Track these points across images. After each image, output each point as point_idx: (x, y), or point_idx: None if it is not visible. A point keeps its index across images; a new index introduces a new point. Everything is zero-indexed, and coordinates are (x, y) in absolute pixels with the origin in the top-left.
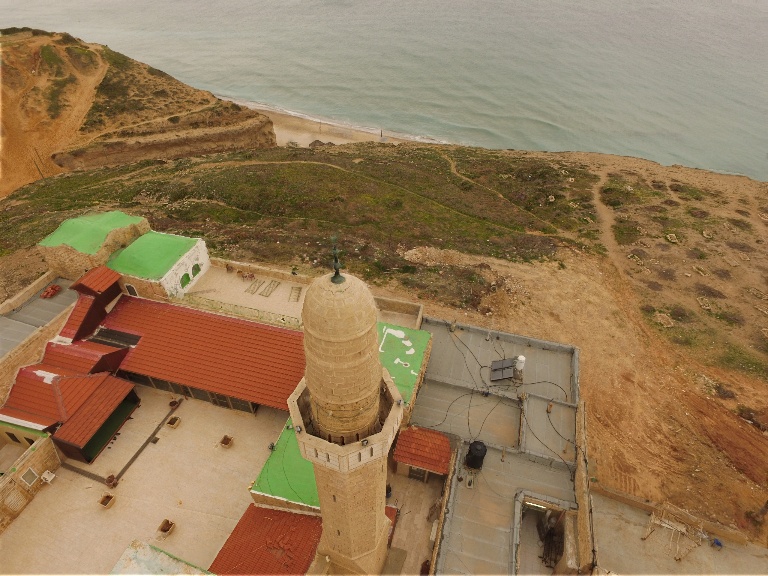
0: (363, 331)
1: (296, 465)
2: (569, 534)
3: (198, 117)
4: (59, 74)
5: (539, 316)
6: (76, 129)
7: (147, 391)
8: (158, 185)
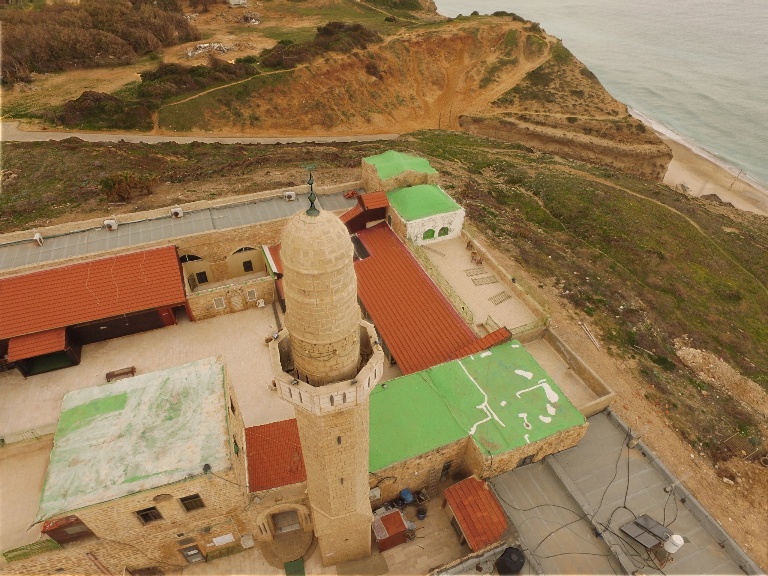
0: (307, 270)
1: None
2: None
3: (596, 125)
4: (508, 55)
5: None
6: (490, 101)
7: None
8: (507, 166)
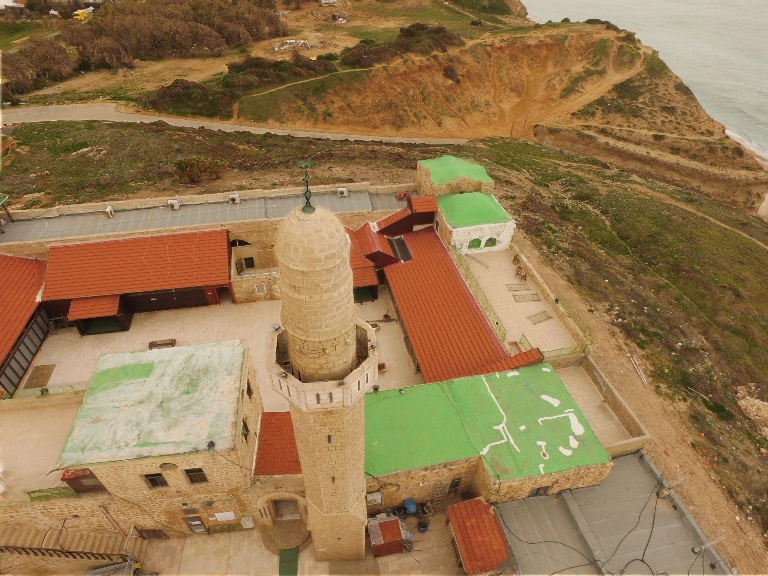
0: (297, 266)
1: (373, 416)
2: None
3: (685, 144)
4: (596, 64)
5: None
6: (569, 112)
7: (386, 297)
8: (577, 181)
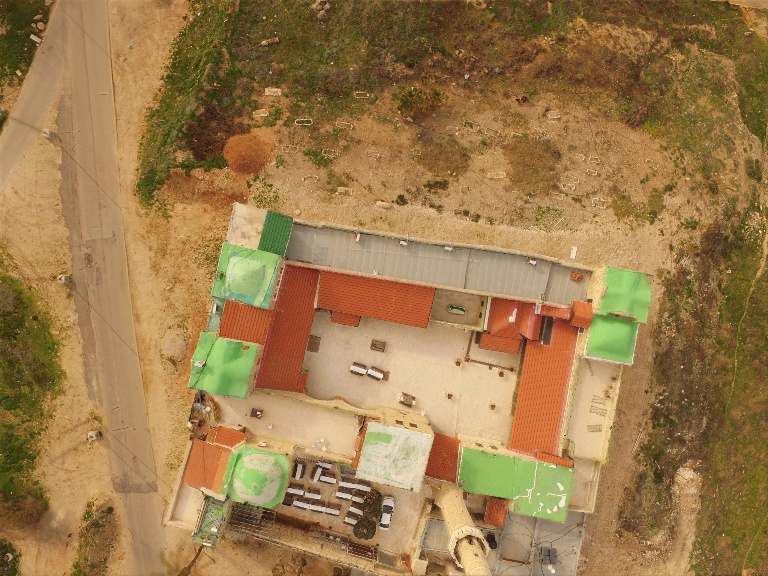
0: None
1: (476, 464)
2: (462, 575)
3: None
4: None
5: (622, 570)
6: None
7: None
8: None
